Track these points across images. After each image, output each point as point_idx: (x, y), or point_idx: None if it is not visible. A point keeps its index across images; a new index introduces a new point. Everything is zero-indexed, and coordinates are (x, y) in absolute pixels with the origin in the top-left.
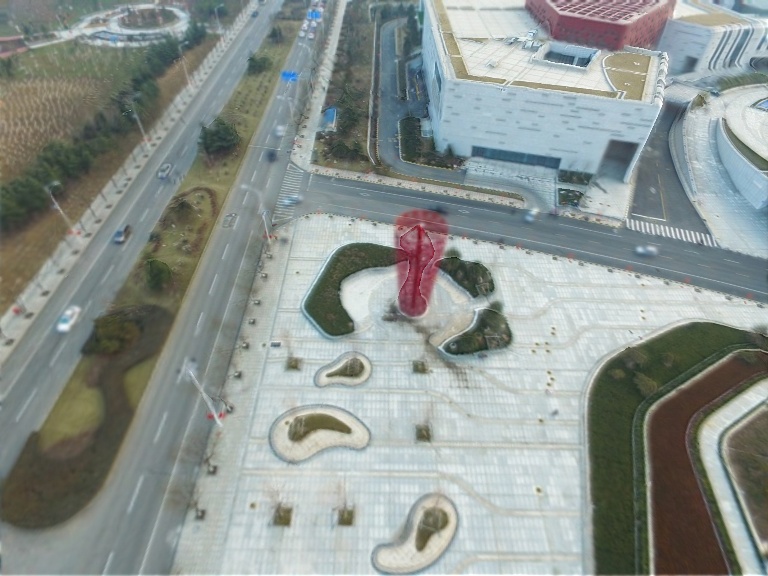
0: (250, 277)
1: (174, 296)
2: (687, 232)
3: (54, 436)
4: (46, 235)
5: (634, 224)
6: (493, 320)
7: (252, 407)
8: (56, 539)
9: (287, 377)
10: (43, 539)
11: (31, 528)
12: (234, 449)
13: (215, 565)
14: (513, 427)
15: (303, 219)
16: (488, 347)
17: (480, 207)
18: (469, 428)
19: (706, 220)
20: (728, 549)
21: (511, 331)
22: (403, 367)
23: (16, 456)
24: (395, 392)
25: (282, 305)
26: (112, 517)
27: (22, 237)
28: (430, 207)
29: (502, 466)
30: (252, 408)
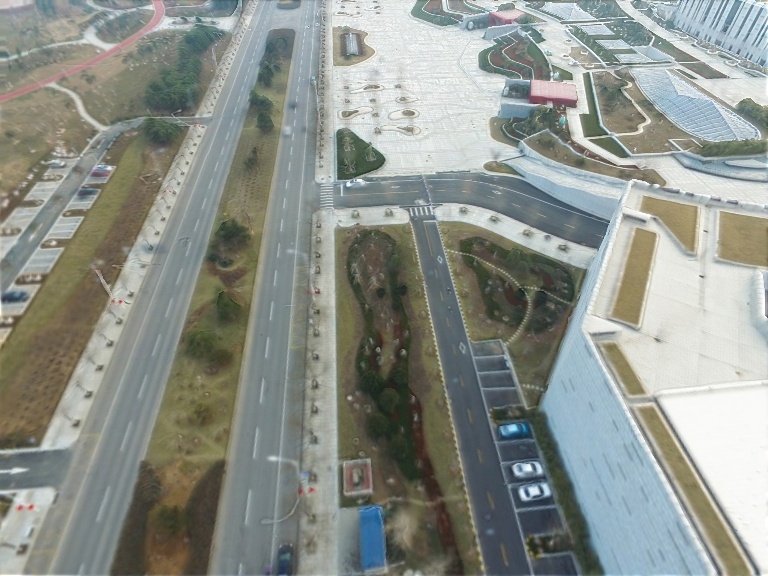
0: None
1: None
2: None
3: None
4: None
5: None
6: None
7: (331, 0)
8: None
9: None
10: None
11: (288, 9)
12: (329, 3)
13: (331, 10)
14: None
15: None
16: None
17: None
18: None
19: None
20: (441, 3)
21: None
22: None
23: (276, 4)
24: None
25: None
26: (305, 8)
27: None
28: None
29: (395, 4)
30: (331, 0)
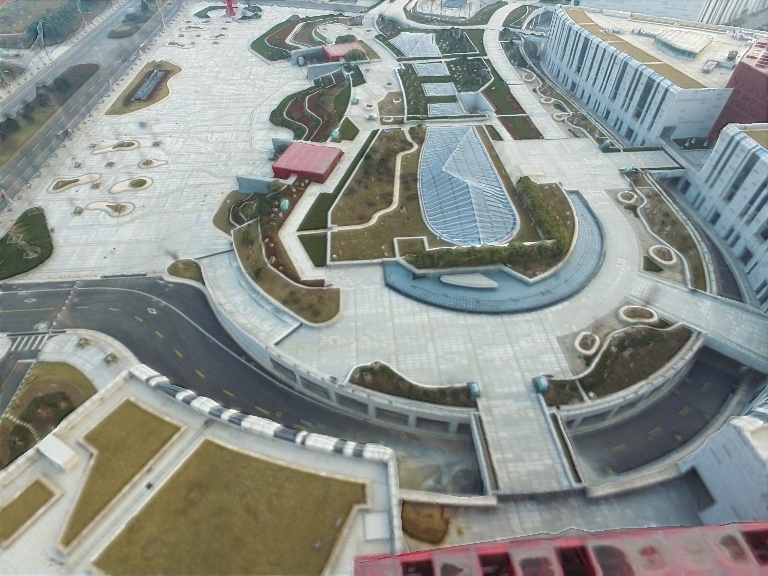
0: (176, 11)
1: (150, 14)
2: (347, 3)
3: (118, 30)
4: (101, 7)
5: (328, 2)
6: (255, 14)
7: None
8: (124, 39)
9: None
10: (120, 39)
11: (117, 38)
12: None
13: None
14: (251, 28)
15: (198, 3)
16: (252, 18)
17: (270, 0)
18: (238, 28)
19: (358, 1)
20: None
21: (262, 17)
22: (223, 22)
23: None
24: None
25: (187, 15)
26: None
27: (93, 6)
28: (249, 0)
29: None
30: None
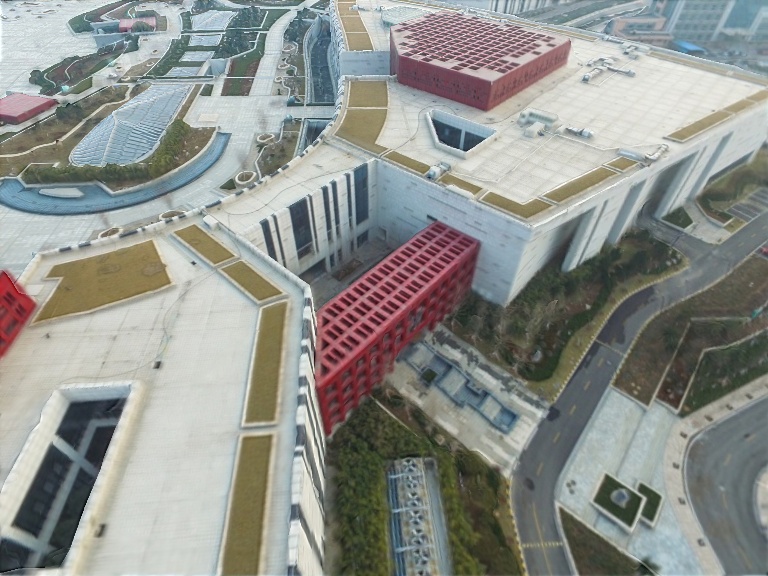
0: None
1: None
2: None
3: None
4: None
5: None
6: None
7: None
8: None
9: (26, 0)
10: None
11: None
12: None
13: None
14: None
15: None
16: None
17: None
18: None
19: None
20: None
21: None
22: None
23: None
24: (57, 2)
25: None
26: None
27: None
28: None
29: (77, 8)
30: None
